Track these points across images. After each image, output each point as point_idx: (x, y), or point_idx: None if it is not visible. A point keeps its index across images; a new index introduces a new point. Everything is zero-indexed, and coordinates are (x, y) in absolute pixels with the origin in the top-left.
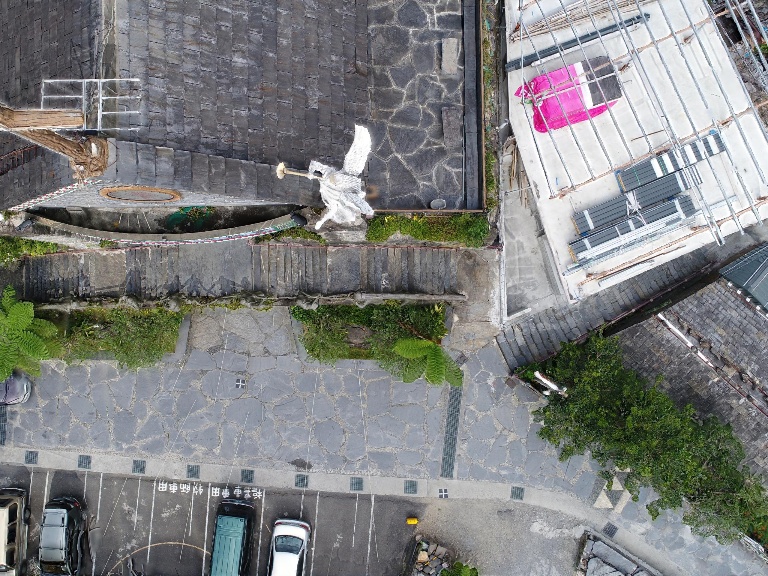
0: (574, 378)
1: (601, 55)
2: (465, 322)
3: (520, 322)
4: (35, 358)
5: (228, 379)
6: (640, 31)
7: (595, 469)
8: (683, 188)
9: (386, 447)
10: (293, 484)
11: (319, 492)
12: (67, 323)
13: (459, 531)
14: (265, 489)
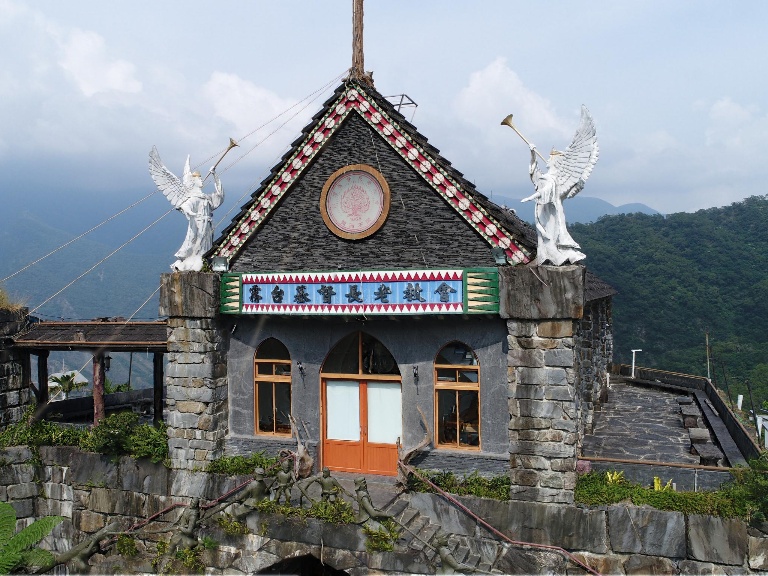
0: None
1: None
2: None
3: None
4: None
5: None
6: None
7: None
8: None
9: None
10: None
11: None
12: None
13: None
14: None
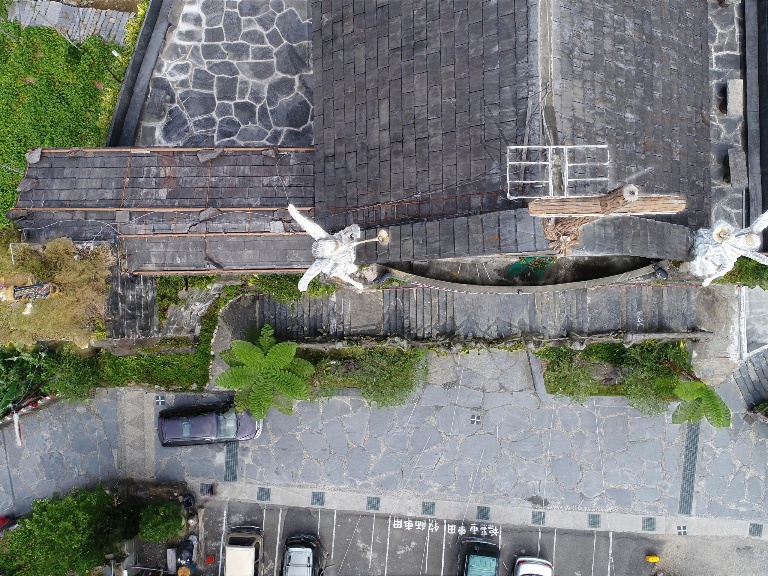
0: None
1: None
2: (704, 358)
3: (752, 357)
4: (293, 398)
5: (463, 415)
6: None
7: None
8: None
9: (624, 484)
10: (529, 521)
11: (556, 529)
12: None
13: (698, 568)
14: (501, 526)
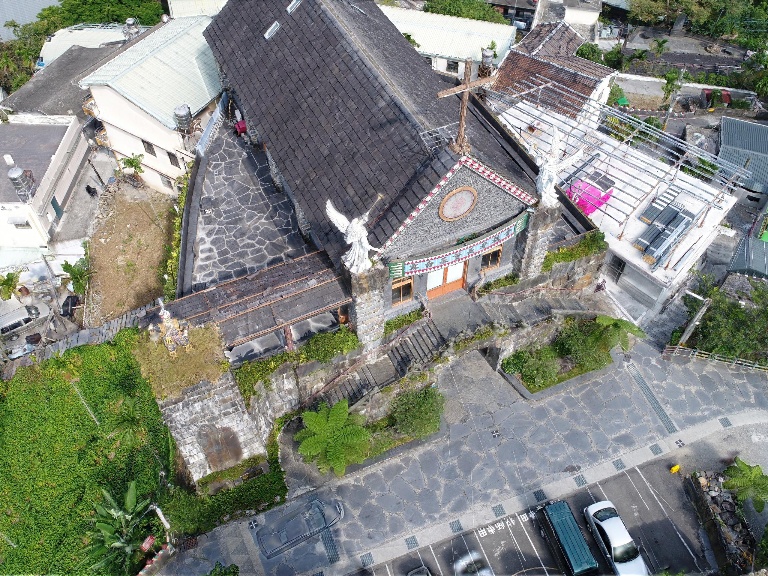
0: None
1: None
2: None
3: (643, 330)
4: None
5: (485, 435)
6: None
7: (758, 388)
8: (678, 210)
9: (620, 431)
10: (576, 486)
11: (598, 482)
12: None
13: (710, 463)
14: (558, 499)
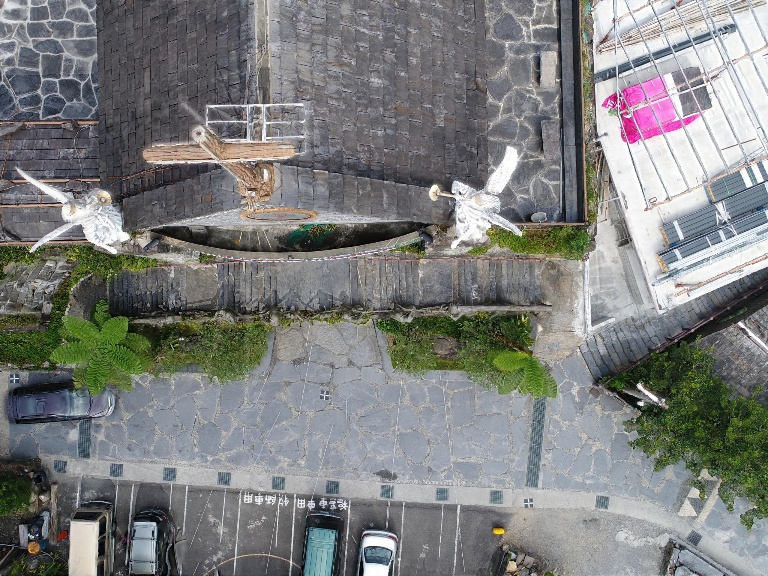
0: (672, 389)
1: (688, 66)
2: (549, 332)
3: (601, 331)
4: (128, 372)
5: (312, 391)
6: (727, 41)
7: (679, 478)
8: None
9: (471, 457)
10: (378, 495)
11: (404, 503)
12: (152, 336)
13: (545, 540)
14: (350, 500)
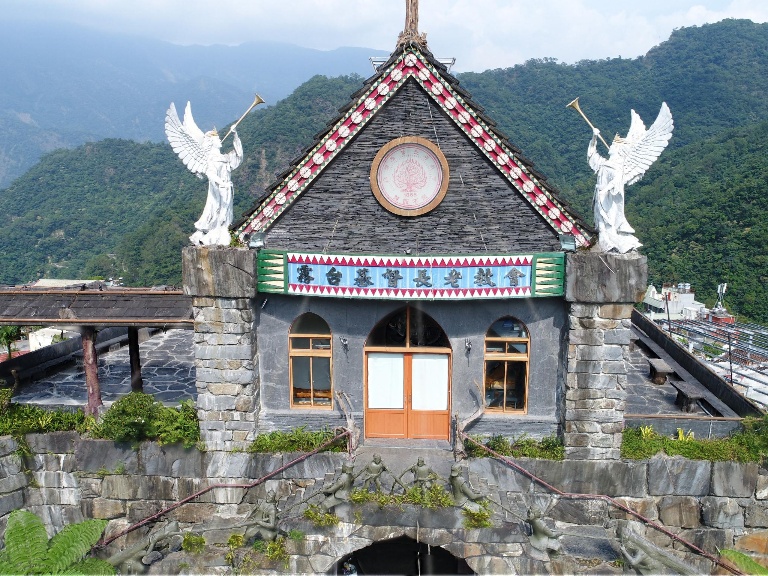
0: None
1: None
2: None
3: None
4: None
5: None
6: None
7: None
8: None
9: None
10: None
11: None
12: None
13: None
14: None
